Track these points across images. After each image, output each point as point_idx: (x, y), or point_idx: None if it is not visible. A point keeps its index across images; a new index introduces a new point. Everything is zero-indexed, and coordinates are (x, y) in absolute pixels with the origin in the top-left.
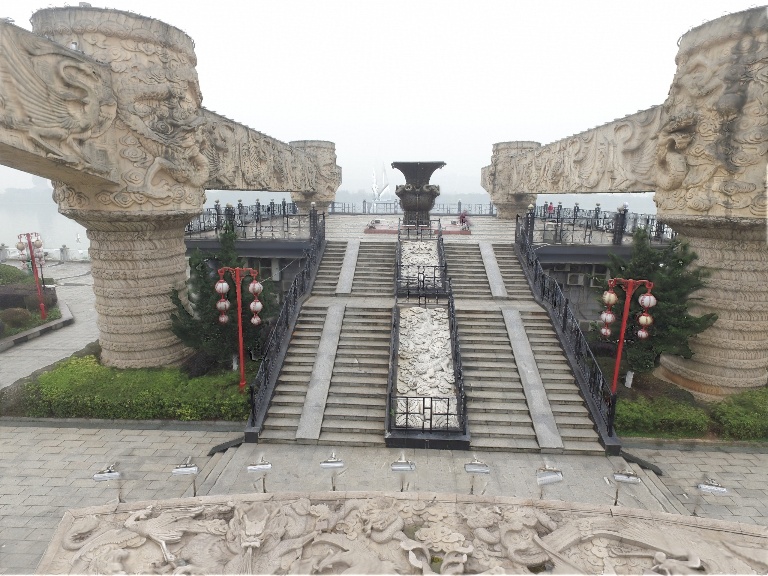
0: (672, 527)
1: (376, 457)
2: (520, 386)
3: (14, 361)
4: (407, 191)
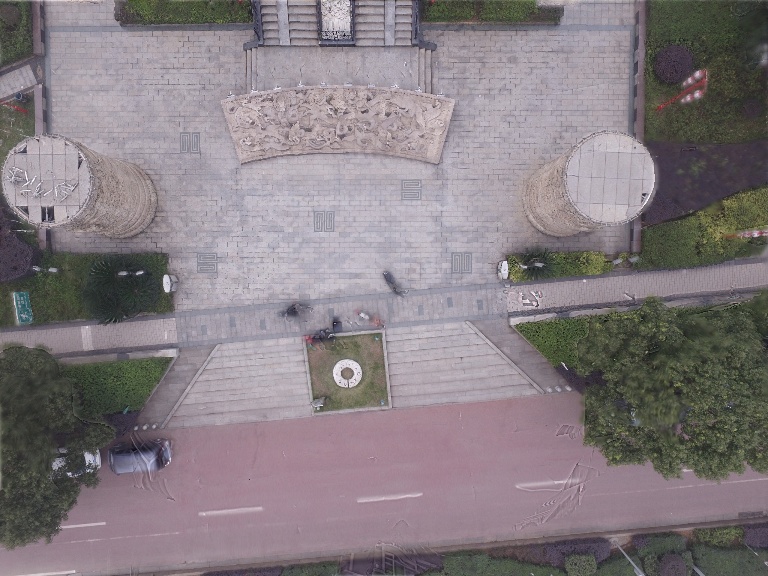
0: (407, 97)
1: (316, 54)
2: (383, 4)
3: None
4: None
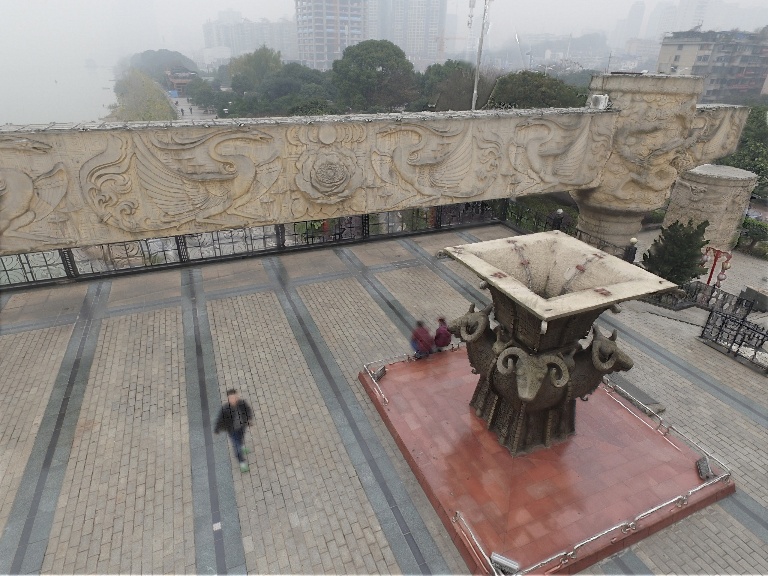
0: None
1: None
2: None
3: None
4: None
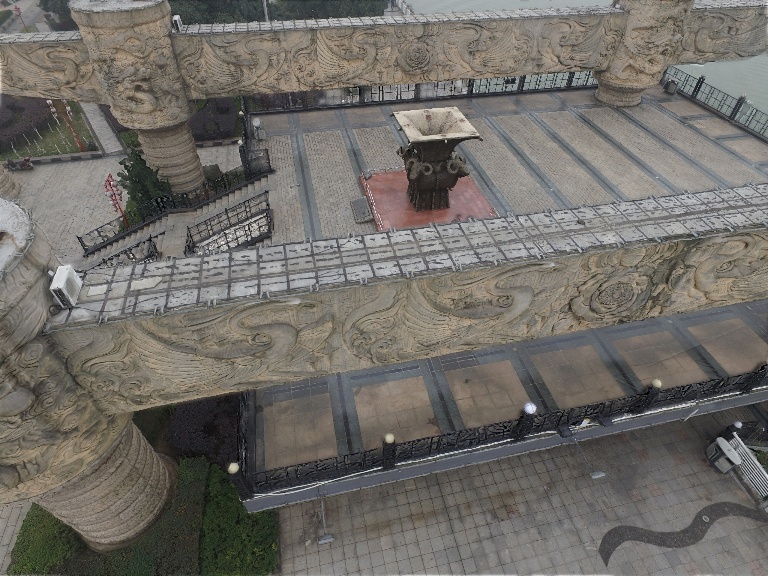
0: None
1: None
2: None
3: (210, 155)
4: (406, 155)
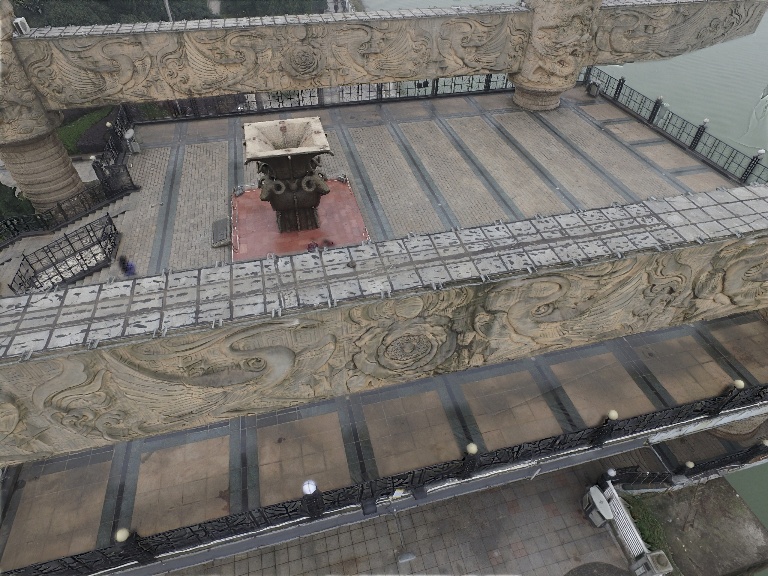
0: None
1: None
2: None
3: None
4: (265, 170)
